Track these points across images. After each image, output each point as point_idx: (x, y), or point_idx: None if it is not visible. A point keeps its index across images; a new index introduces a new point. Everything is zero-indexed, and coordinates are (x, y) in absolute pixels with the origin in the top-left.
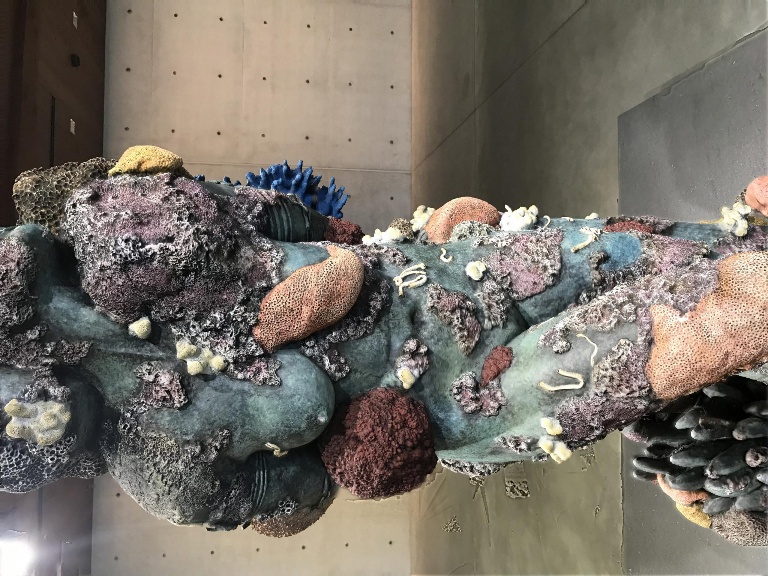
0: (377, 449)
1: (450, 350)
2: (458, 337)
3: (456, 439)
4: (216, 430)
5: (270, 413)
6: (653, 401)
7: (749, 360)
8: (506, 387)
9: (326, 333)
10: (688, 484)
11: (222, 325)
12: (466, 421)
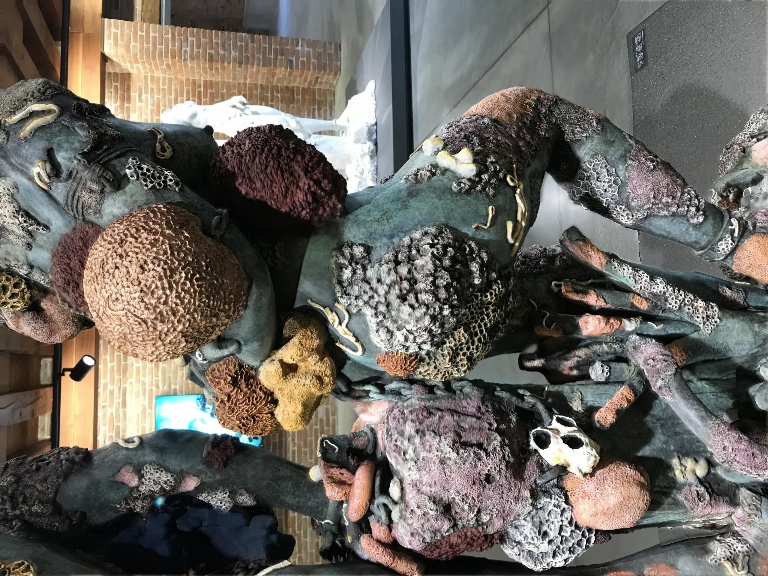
0: None
1: None
2: None
3: (364, 194)
4: None
5: None
6: None
7: None
8: None
9: None
10: None
11: None
12: None
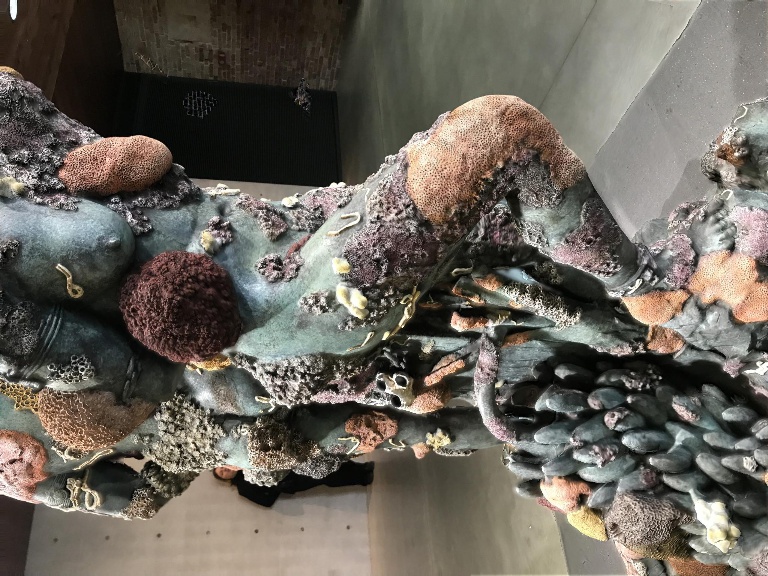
0: (168, 277)
1: (255, 234)
2: (263, 224)
3: (262, 310)
4: (6, 240)
5: (62, 231)
6: (423, 225)
7: (485, 164)
8: (303, 252)
9: (133, 199)
10: (559, 464)
11: (29, 161)
12: (270, 289)
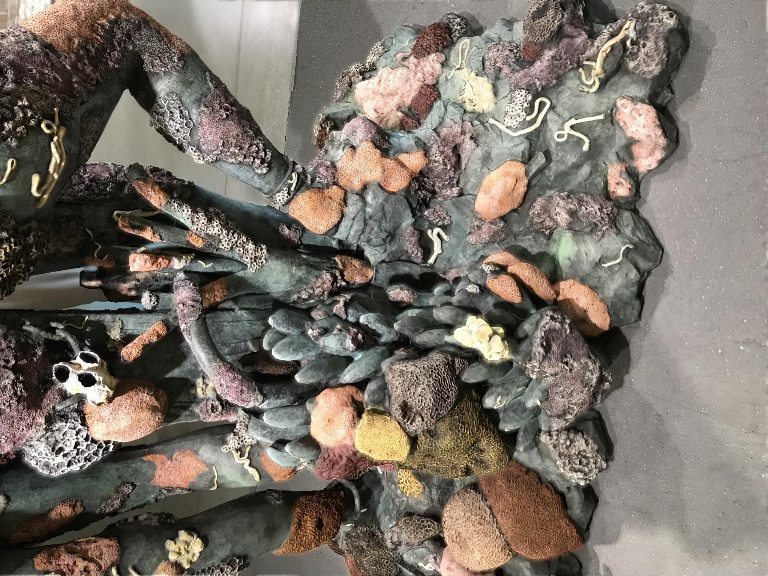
0: None
1: None
2: None
3: None
4: None
5: None
6: (47, 48)
7: (97, 12)
8: None
9: None
10: (310, 363)
11: None
12: None
